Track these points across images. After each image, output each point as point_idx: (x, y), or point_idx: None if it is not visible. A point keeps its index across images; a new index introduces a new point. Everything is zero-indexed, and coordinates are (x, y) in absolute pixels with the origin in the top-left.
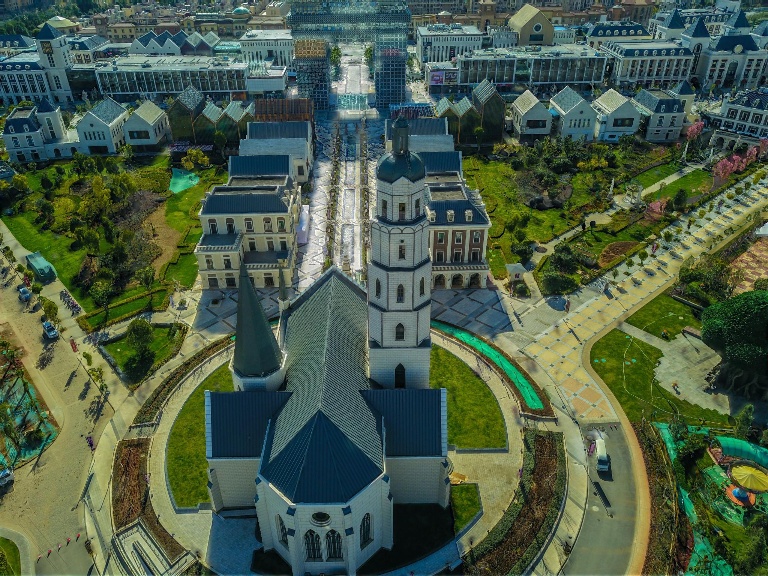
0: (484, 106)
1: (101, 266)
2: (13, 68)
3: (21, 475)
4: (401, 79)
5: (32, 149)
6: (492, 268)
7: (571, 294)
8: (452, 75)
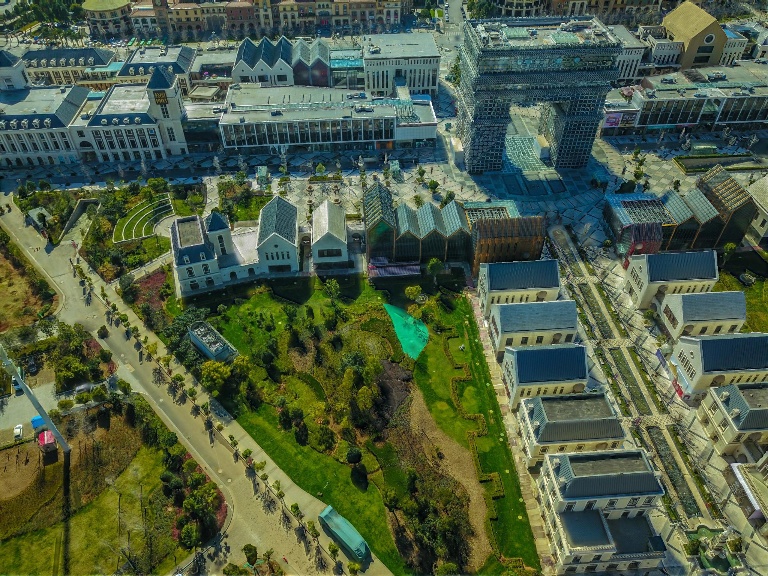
0: (733, 213)
1: (416, 531)
2: (120, 122)
3: None
4: (590, 138)
5: (207, 276)
6: None
7: None
8: (630, 117)
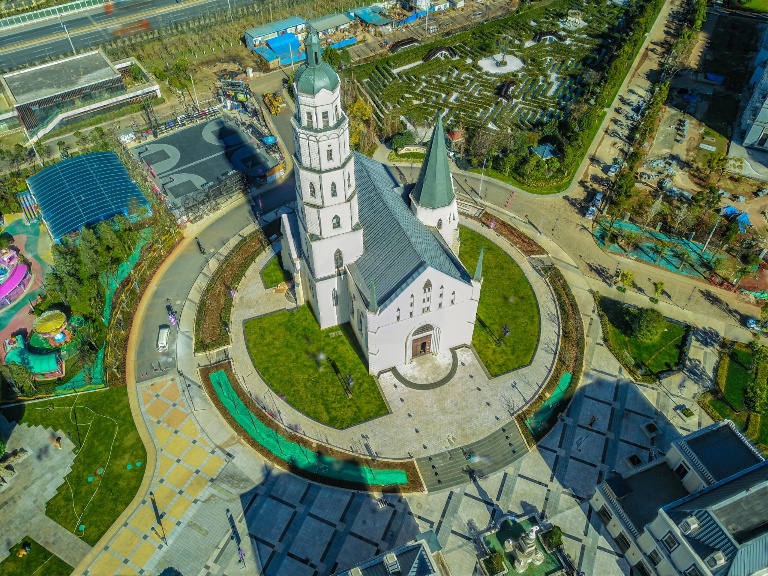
0: None
1: None
2: None
3: (585, 221)
4: None
5: None
6: None
7: None
8: None
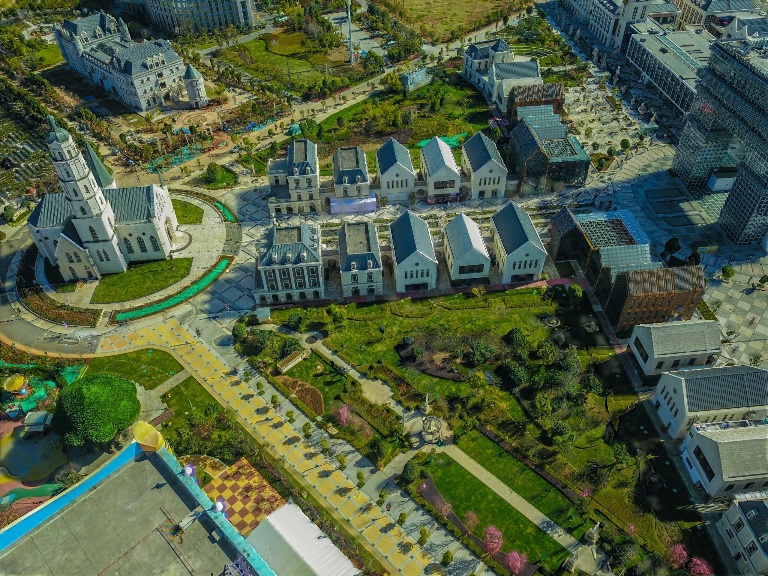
0: (617, 277)
1: None
2: (605, 5)
3: (140, 172)
4: (749, 210)
5: None
6: (285, 309)
7: (235, 350)
8: None
